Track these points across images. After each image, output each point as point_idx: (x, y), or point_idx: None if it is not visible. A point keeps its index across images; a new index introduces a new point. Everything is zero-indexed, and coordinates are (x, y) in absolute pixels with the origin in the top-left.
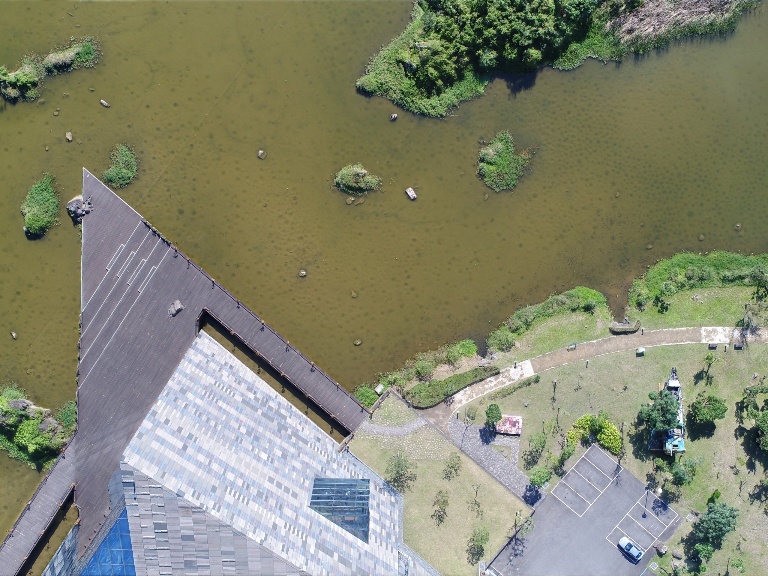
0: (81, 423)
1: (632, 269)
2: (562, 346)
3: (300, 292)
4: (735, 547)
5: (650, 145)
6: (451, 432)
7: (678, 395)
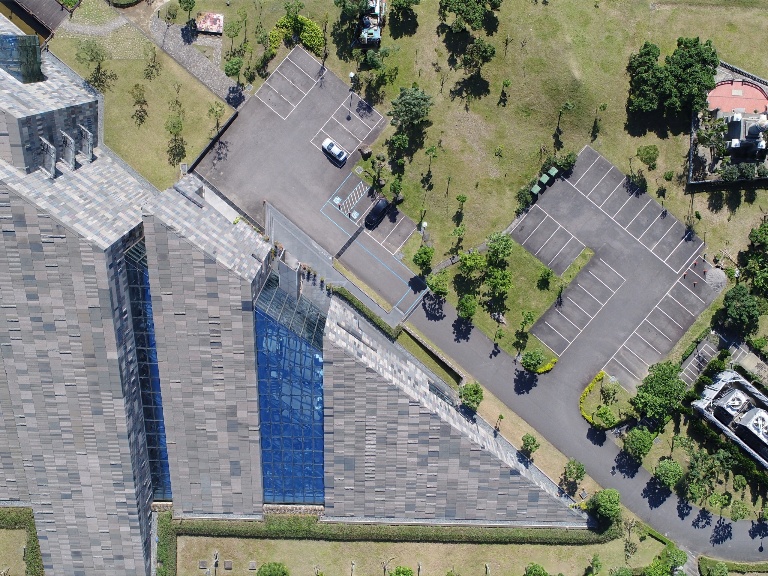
0: None
1: None
2: None
3: None
4: (437, 145)
5: None
6: (152, 31)
7: None
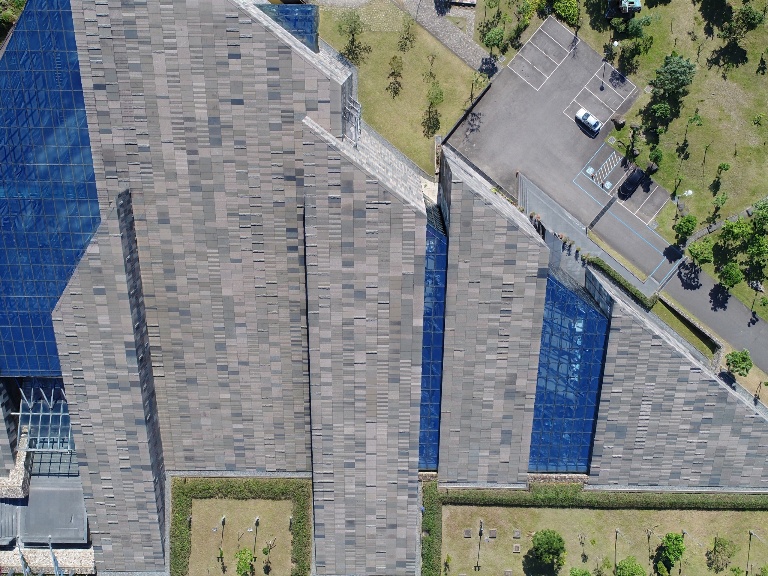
0: None
1: None
2: None
3: None
4: (693, 114)
5: None
6: (406, 3)
7: None
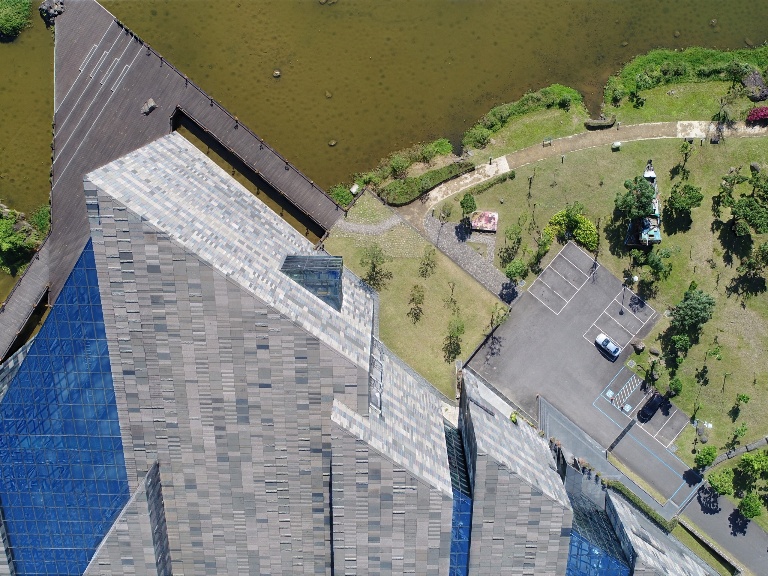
0: (55, 223)
1: (607, 66)
2: (537, 142)
3: (274, 93)
4: (712, 341)
5: None
6: (427, 229)
7: (654, 187)
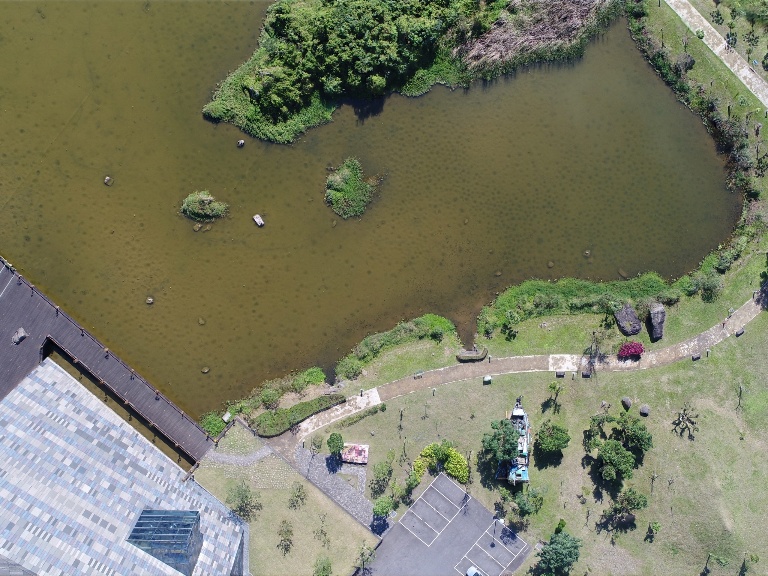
0: None
1: (481, 296)
2: (409, 374)
3: (147, 319)
4: None
5: (499, 171)
6: (297, 461)
7: (523, 424)
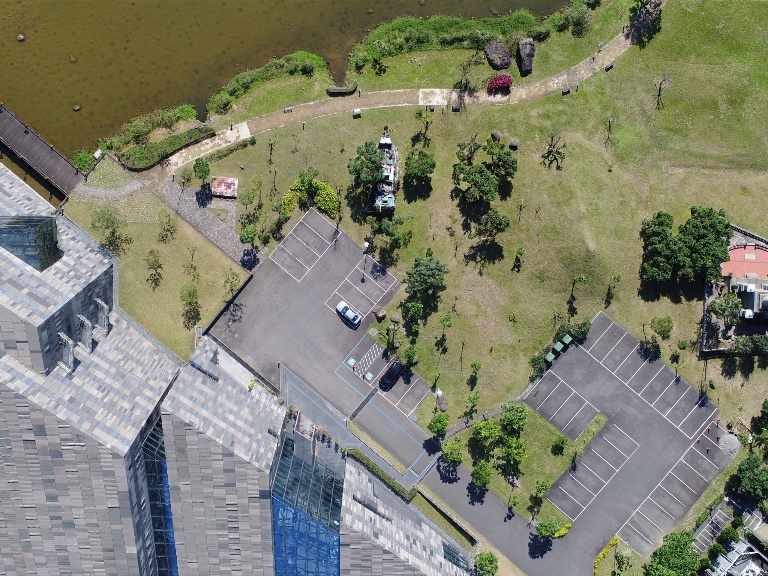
0: None
1: (353, 34)
2: (279, 108)
3: (18, 57)
4: (451, 309)
5: None
6: (167, 195)
7: (391, 153)
